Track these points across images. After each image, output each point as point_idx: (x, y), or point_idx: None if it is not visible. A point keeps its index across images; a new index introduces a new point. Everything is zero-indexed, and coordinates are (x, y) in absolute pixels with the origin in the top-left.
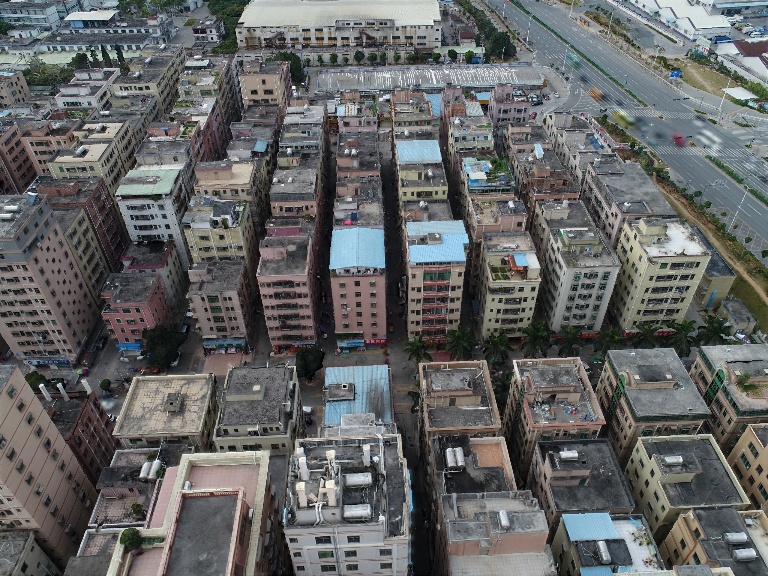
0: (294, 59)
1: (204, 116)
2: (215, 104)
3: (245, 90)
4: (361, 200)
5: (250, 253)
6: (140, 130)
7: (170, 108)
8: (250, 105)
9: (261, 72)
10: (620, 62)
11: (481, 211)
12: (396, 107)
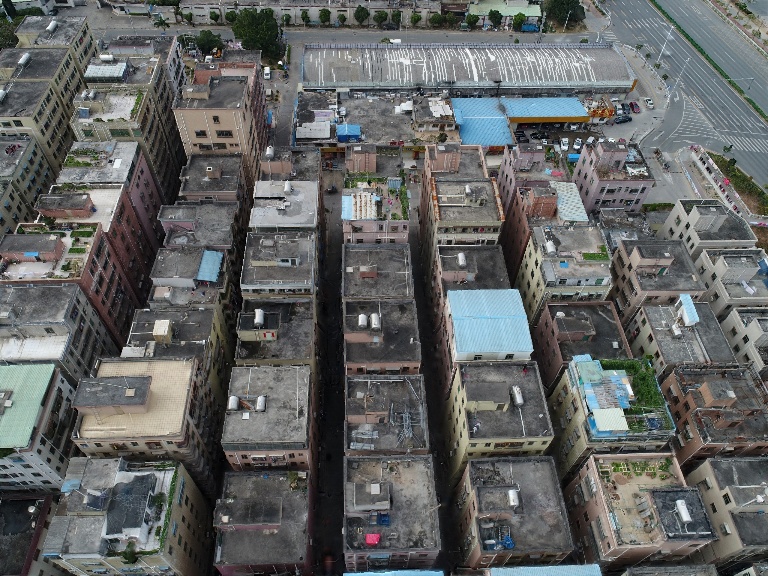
0: (267, 23)
1: (114, 189)
2: (135, 156)
3: (185, 130)
4: (393, 458)
5: (188, 546)
6: (1, 220)
7: (66, 142)
8: (195, 154)
9: (211, 100)
10: (729, 40)
11: (614, 492)
12: (439, 191)
